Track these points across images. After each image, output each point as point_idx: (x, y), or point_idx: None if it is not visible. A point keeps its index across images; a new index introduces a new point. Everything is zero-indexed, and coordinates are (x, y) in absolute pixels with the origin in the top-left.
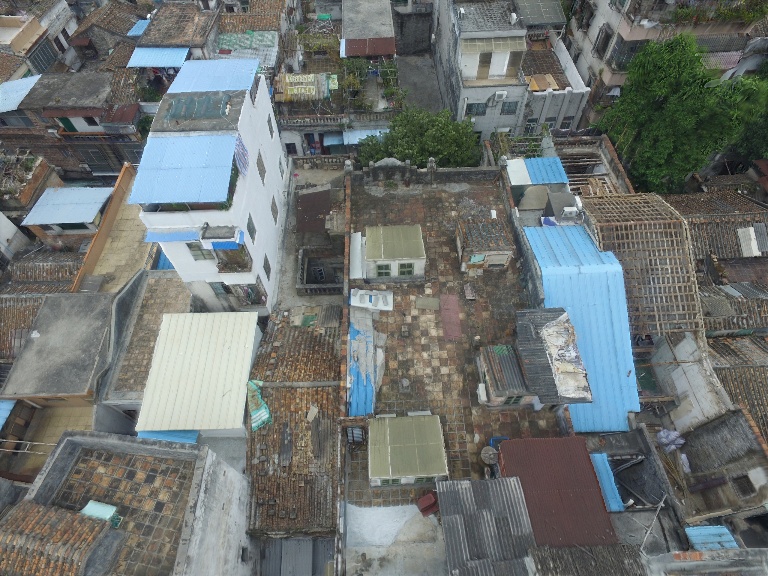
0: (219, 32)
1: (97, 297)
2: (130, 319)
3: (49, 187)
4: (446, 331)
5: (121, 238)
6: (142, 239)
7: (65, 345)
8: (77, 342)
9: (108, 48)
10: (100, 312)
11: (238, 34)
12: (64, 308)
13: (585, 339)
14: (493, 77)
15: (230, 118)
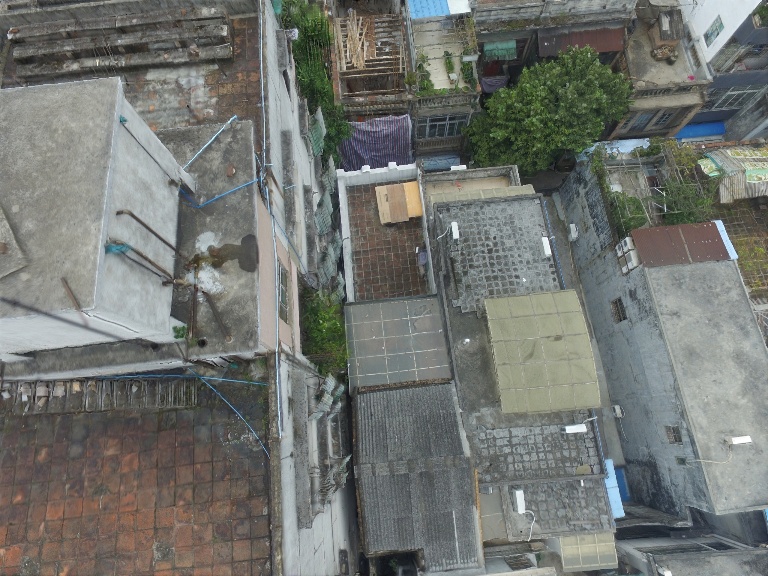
0: None
1: None
2: None
3: None
4: None
5: None
6: None
7: None
8: None
9: None
10: None
11: None
12: None
13: None
14: None
15: None
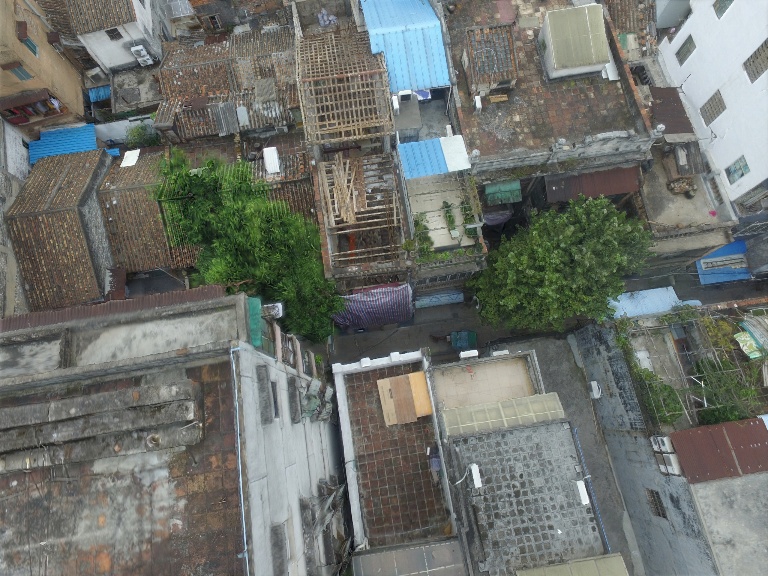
0: None
1: None
2: None
3: None
4: (510, 3)
5: None
6: None
7: None
8: None
9: None
10: None
11: None
12: None
13: (399, 6)
14: None
15: None
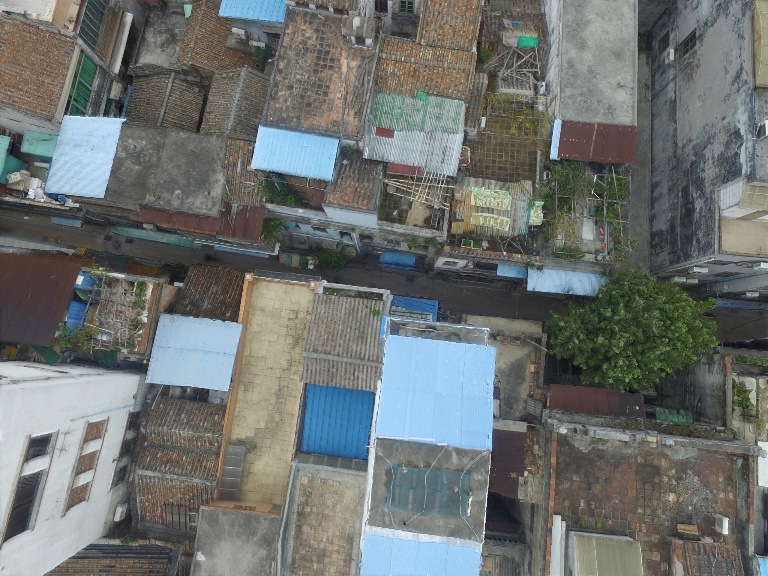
0: (377, 91)
1: (256, 516)
2: (288, 530)
3: (163, 313)
4: None
5: (254, 386)
6: (279, 391)
7: (233, 575)
8: (245, 573)
9: (182, 2)
10: (262, 537)
11: (405, 98)
12: (223, 526)
13: None
14: (760, 220)
15: (472, 521)
